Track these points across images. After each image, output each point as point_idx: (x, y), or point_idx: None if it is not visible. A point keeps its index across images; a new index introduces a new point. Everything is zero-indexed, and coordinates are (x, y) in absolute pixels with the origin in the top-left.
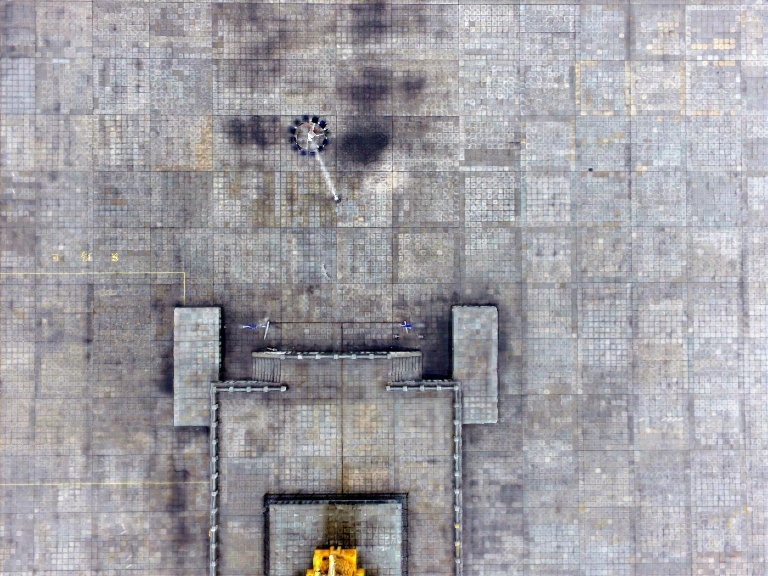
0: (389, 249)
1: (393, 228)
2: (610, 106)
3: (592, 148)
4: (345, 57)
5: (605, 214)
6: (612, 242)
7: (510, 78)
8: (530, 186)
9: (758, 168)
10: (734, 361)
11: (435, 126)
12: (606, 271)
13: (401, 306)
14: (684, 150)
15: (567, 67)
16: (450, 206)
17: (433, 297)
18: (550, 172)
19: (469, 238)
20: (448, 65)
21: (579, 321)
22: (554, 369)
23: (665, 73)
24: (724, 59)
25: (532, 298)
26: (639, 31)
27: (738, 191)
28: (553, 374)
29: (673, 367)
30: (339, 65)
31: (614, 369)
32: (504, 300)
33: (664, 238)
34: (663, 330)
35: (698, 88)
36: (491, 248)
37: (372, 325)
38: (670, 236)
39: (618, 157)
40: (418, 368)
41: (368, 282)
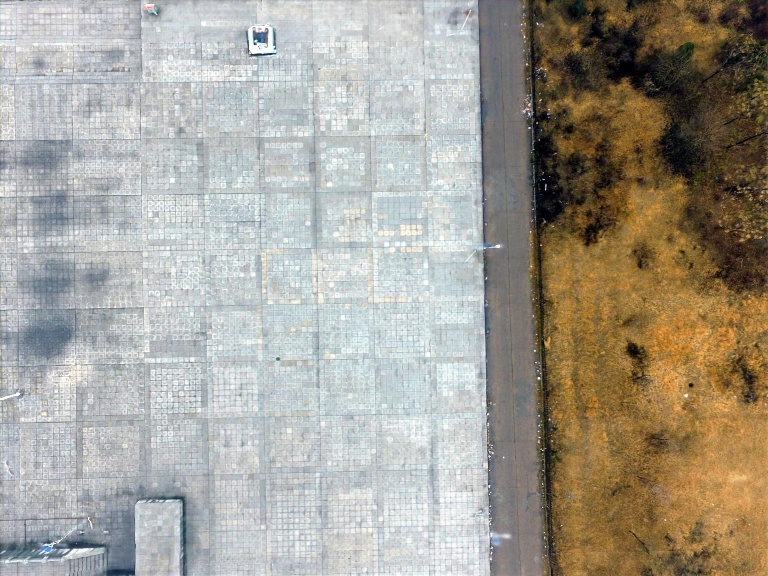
0: (73, 444)
1: (77, 422)
2: (297, 294)
3: (279, 337)
4: (26, 250)
5: (293, 403)
6: (300, 431)
7: (195, 268)
8: (217, 377)
9: (447, 354)
10: (425, 549)
11: (119, 318)
12: (294, 461)
13: (86, 501)
14: (372, 337)
15: (253, 256)
16: (135, 399)
17: (119, 491)
18: (237, 362)
19: (155, 431)
20: (131, 256)
21: (267, 512)
22: (242, 562)
23: (352, 260)
24: (411, 245)
25: (219, 490)
26: (325, 219)
27: (427, 378)
28: (241, 567)
29: (363, 557)
30: (20, 259)
31: (303, 560)
32: (191, 493)
33: (353, 427)
34: (353, 520)
35: (386, 275)
36: (177, 440)
37: (56, 521)
38: (359, 424)
39: (306, 346)
40: (102, 565)
41: (52, 478)
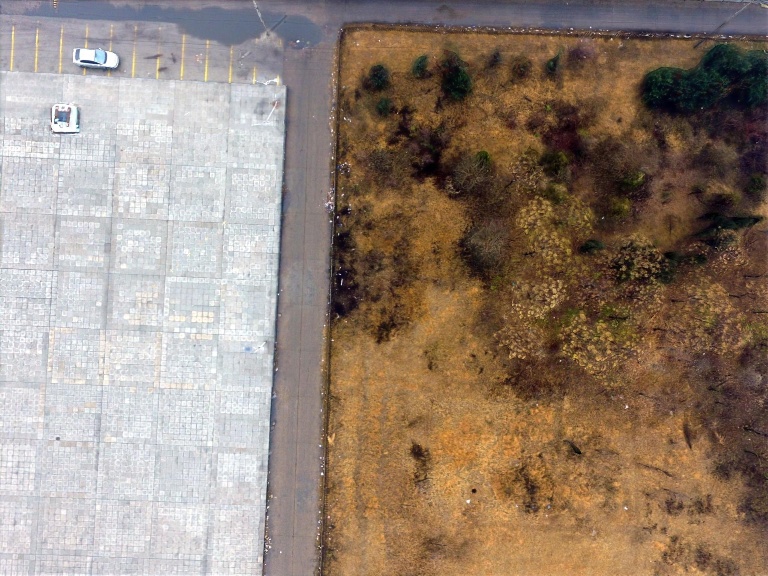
0: None
1: None
2: (82, 375)
3: (61, 417)
4: None
5: (70, 485)
6: (75, 514)
7: None
8: None
9: (229, 444)
10: None
11: None
12: (66, 543)
13: None
14: (155, 423)
15: (41, 333)
16: None
17: None
18: (16, 439)
19: None
20: None
21: None
22: None
23: (141, 344)
24: (202, 332)
25: None
26: (117, 300)
27: (207, 467)
28: None
29: None
30: None
31: None
32: None
33: (128, 512)
34: None
35: (173, 360)
36: None
37: None
38: (135, 510)
39: (87, 427)
40: None
41: None
